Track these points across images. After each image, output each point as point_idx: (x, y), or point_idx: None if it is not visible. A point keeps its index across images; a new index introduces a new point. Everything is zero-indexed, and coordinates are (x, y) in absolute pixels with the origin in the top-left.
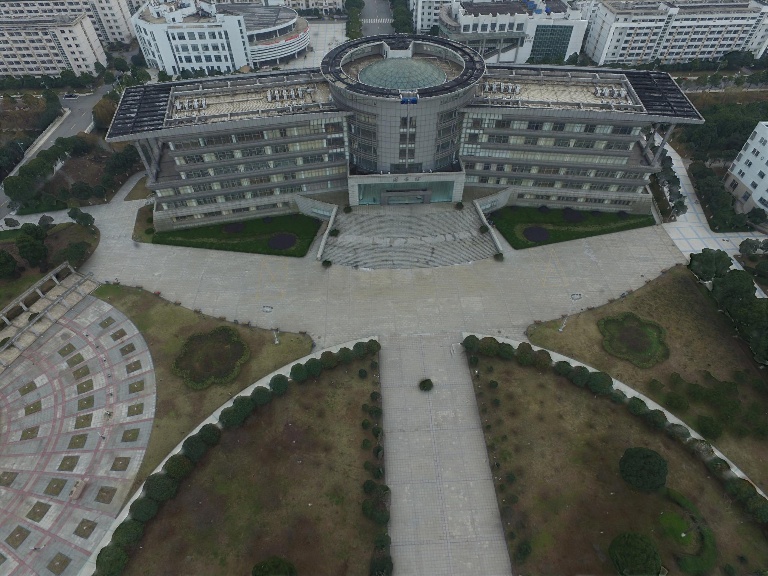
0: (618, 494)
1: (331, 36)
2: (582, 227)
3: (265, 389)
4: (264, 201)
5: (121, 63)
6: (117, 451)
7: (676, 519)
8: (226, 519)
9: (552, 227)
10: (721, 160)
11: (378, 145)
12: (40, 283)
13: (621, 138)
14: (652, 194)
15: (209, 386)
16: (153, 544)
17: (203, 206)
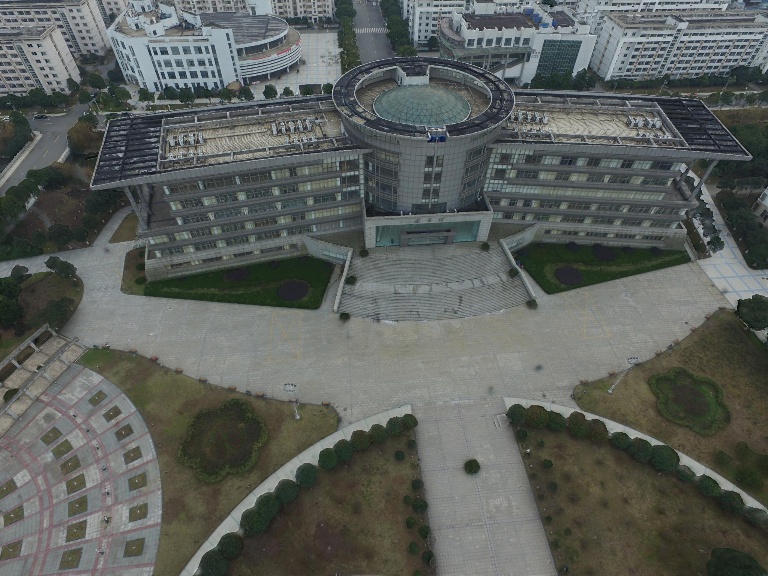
0: None
1: (323, 47)
2: (615, 266)
3: (291, 483)
4: (270, 244)
5: (97, 80)
6: (119, 570)
7: None
8: None
9: (584, 267)
10: None
11: (399, 185)
12: (16, 353)
13: (660, 174)
14: None
15: (224, 478)
16: None
17: (202, 252)
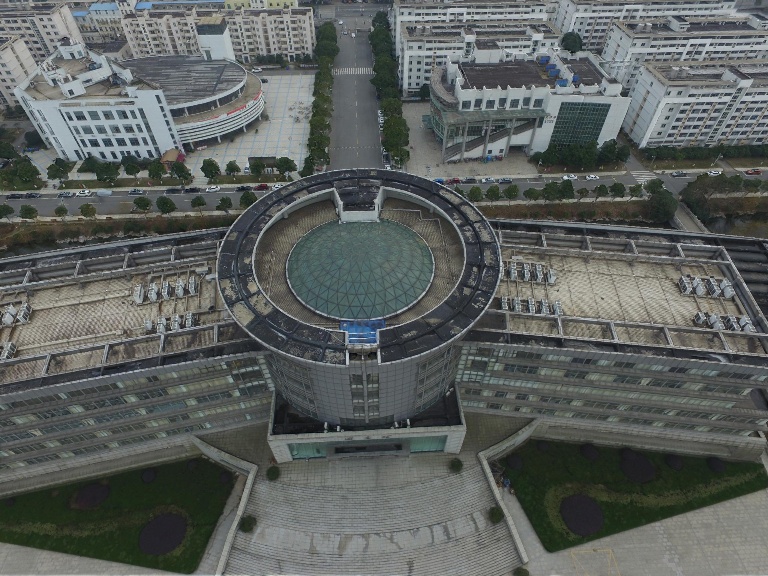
0: None
1: (294, 95)
2: (654, 496)
3: None
4: (141, 449)
5: (2, 149)
6: None
7: None
8: None
9: (606, 496)
10: None
11: (316, 397)
12: None
13: (733, 384)
14: None
15: None
16: None
17: (36, 467)
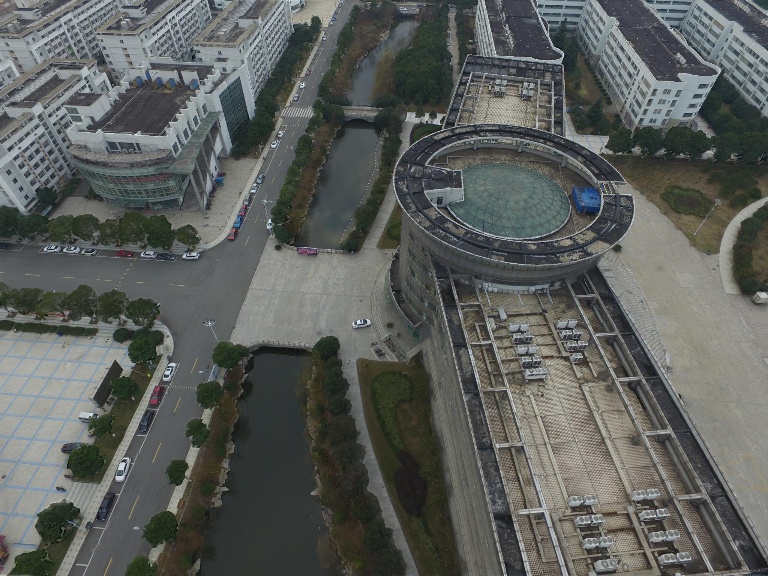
0: None
1: None
2: None
3: None
4: None
5: None
6: None
7: None
8: None
9: None
10: None
11: None
12: None
13: None
14: None
15: None
16: None
17: None
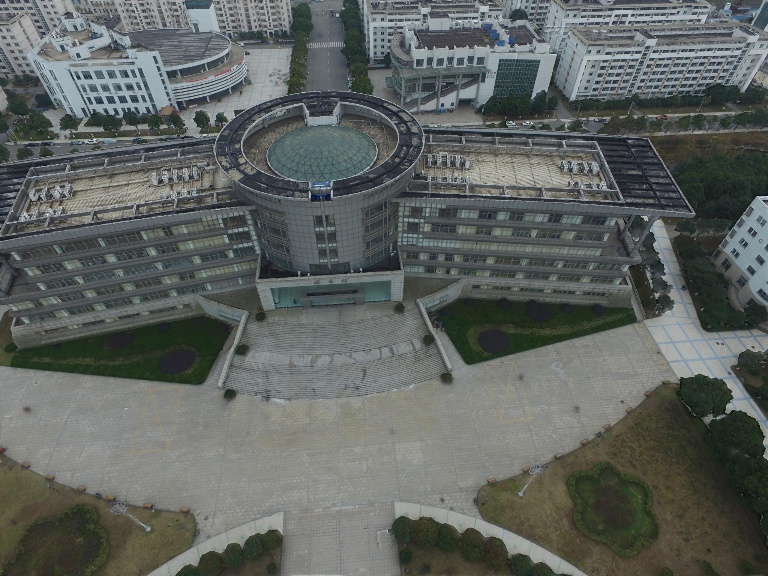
0: None
1: (274, 65)
2: (549, 329)
3: None
4: (157, 305)
5: (18, 106)
6: None
7: None
8: None
9: (513, 330)
10: None
11: (290, 244)
12: None
13: (593, 229)
14: (632, 279)
15: None
16: None
17: (77, 316)
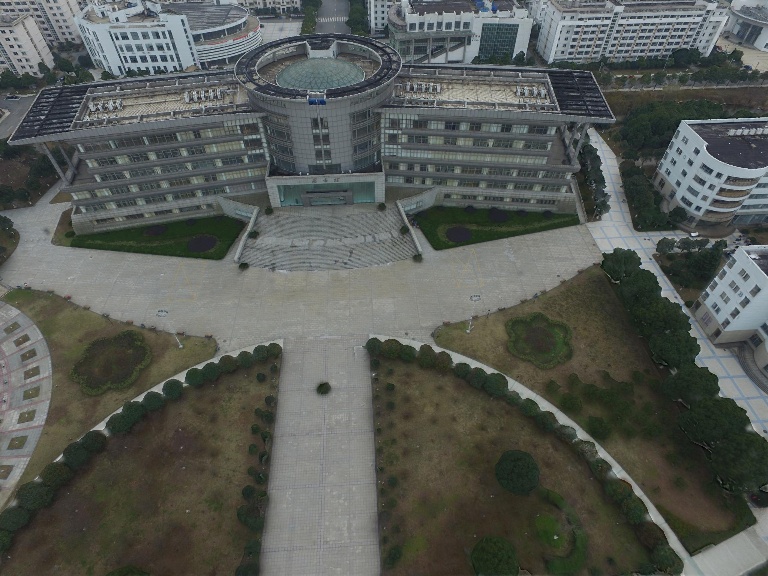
0: (498, 497)
1: (286, 35)
2: (505, 227)
3: (157, 394)
4: (186, 203)
5: (65, 63)
6: (1, 459)
7: (551, 521)
8: (100, 527)
9: (475, 227)
10: (654, 158)
11: (293, 146)
12: None
13: (537, 138)
14: (580, 193)
15: (105, 392)
16: (22, 554)
17: (123, 209)
